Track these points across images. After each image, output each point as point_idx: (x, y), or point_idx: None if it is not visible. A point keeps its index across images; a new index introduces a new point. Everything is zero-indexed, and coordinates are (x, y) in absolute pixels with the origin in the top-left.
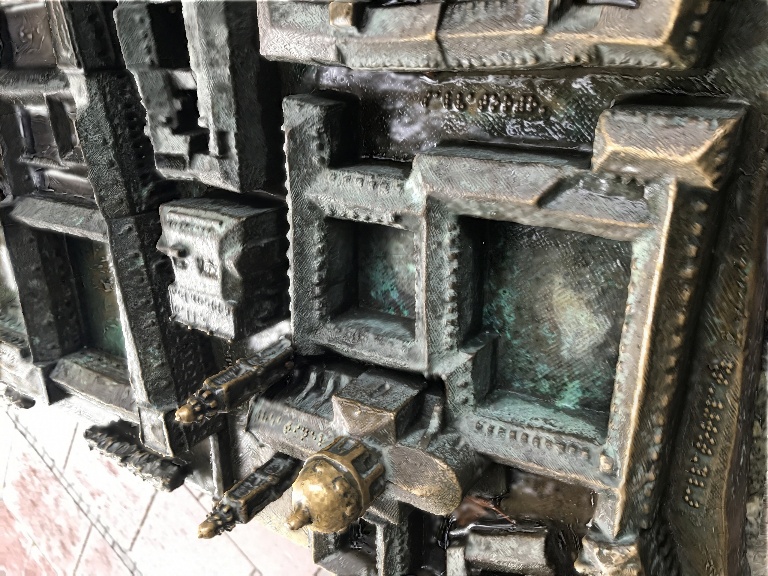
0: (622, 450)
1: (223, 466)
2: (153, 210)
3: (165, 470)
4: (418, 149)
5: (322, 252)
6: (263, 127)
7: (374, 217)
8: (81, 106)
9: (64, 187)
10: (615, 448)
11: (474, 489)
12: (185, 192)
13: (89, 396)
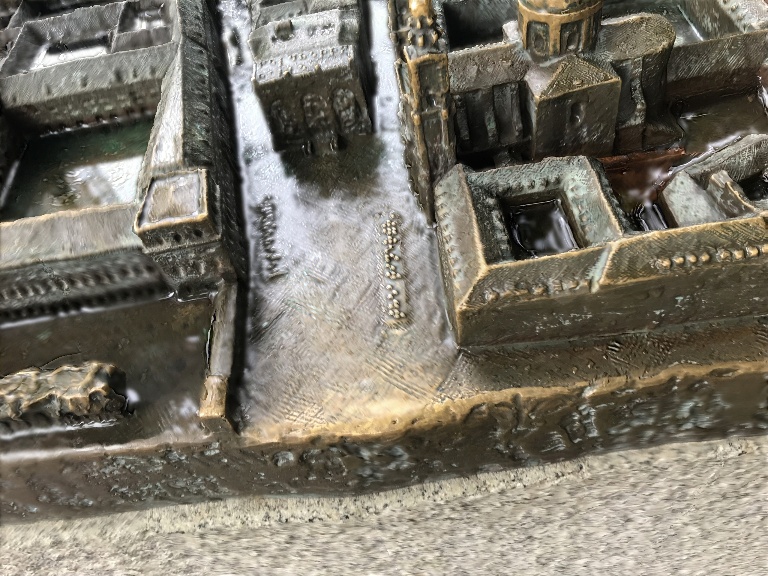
0: (762, 10)
1: (237, 329)
2: None
3: None
4: None
5: (443, 18)
6: (362, 7)
7: None
8: None
9: None
10: (755, 20)
11: (658, 122)
12: (238, 91)
13: (19, 222)
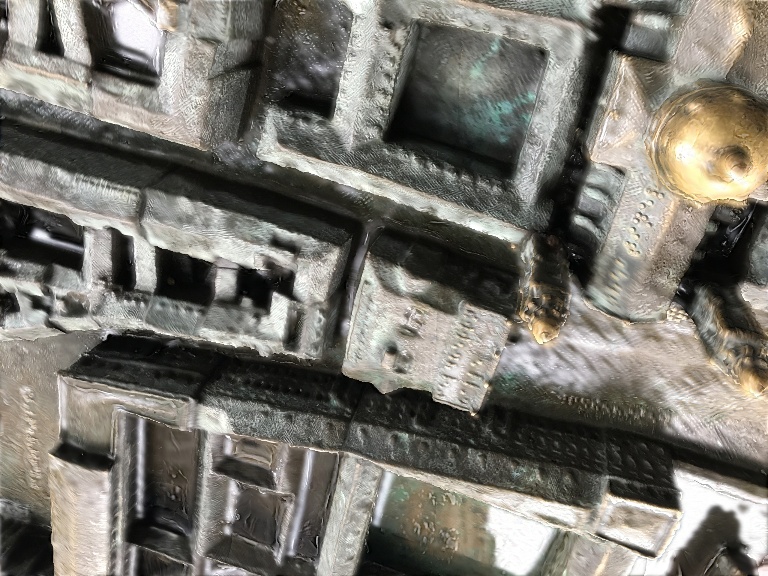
0: None
1: (731, 474)
2: (357, 405)
3: (723, 574)
4: (346, 29)
5: (422, 158)
6: (291, 212)
7: (386, 65)
8: (225, 424)
9: (315, 518)
10: None
11: None
12: None
13: None
